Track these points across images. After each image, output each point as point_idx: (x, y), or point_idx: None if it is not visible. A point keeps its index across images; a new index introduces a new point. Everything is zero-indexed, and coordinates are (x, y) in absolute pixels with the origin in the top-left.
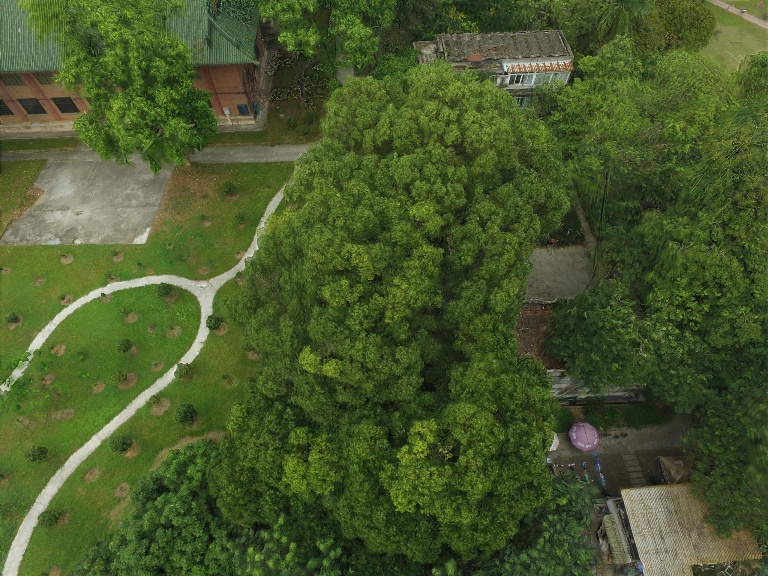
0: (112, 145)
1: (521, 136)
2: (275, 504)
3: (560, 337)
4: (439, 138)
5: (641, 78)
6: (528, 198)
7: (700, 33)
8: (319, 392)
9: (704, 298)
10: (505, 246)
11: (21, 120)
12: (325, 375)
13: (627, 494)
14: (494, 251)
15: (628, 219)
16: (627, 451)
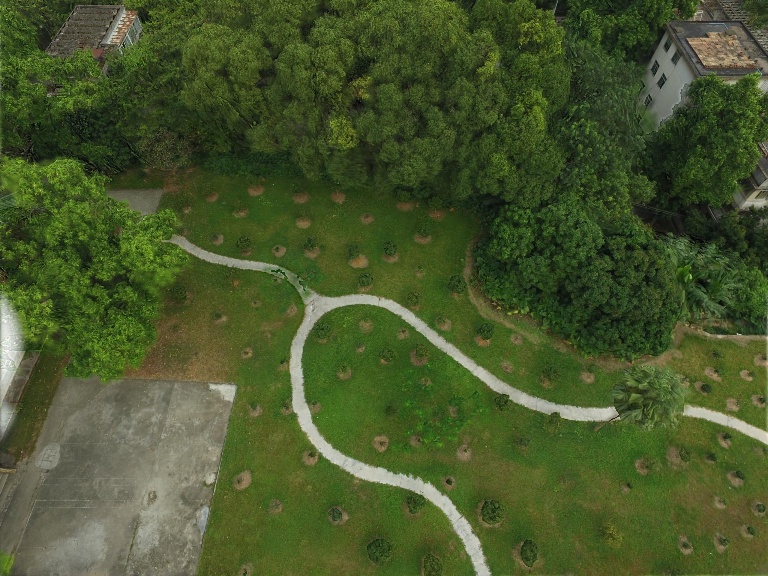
0: None
1: None
2: None
3: None
4: None
5: None
6: None
7: None
8: (498, 84)
9: None
10: None
11: None
12: None
13: None
14: None
15: None
16: None
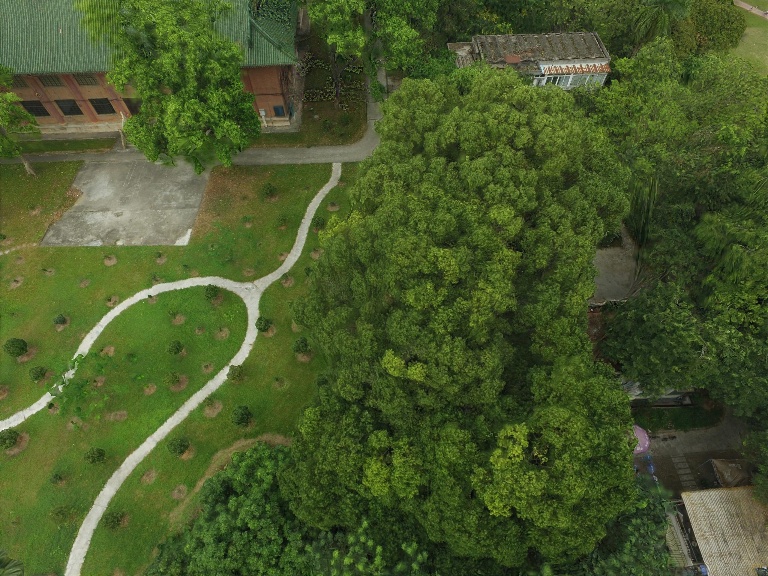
0: (160, 147)
1: (585, 139)
2: (355, 507)
3: (615, 340)
4: (509, 141)
5: (680, 80)
6: (592, 201)
7: (731, 35)
8: (401, 395)
9: (767, 301)
10: (578, 249)
11: (57, 121)
12: (409, 378)
13: (688, 497)
14: (569, 254)
15: (678, 221)
16: (676, 453)
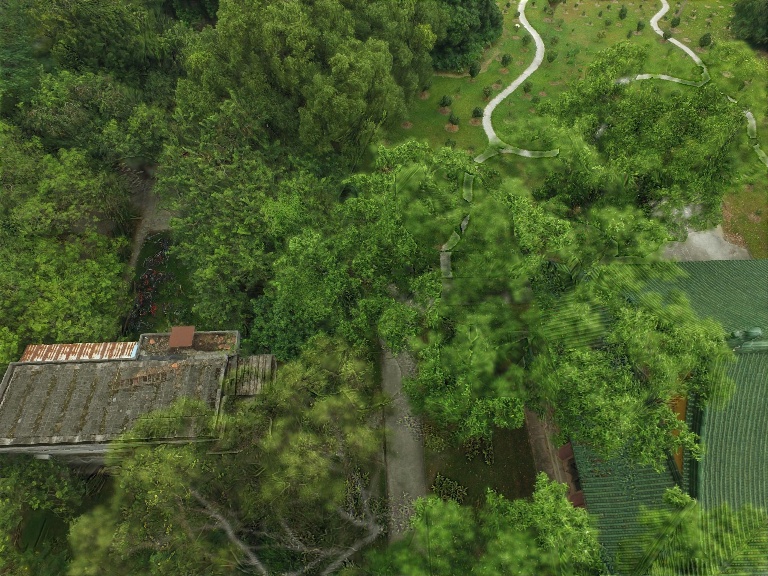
0: None
1: None
2: None
3: None
4: None
5: None
6: None
7: None
8: None
9: None
10: None
11: None
12: None
13: None
14: None
15: None
16: None
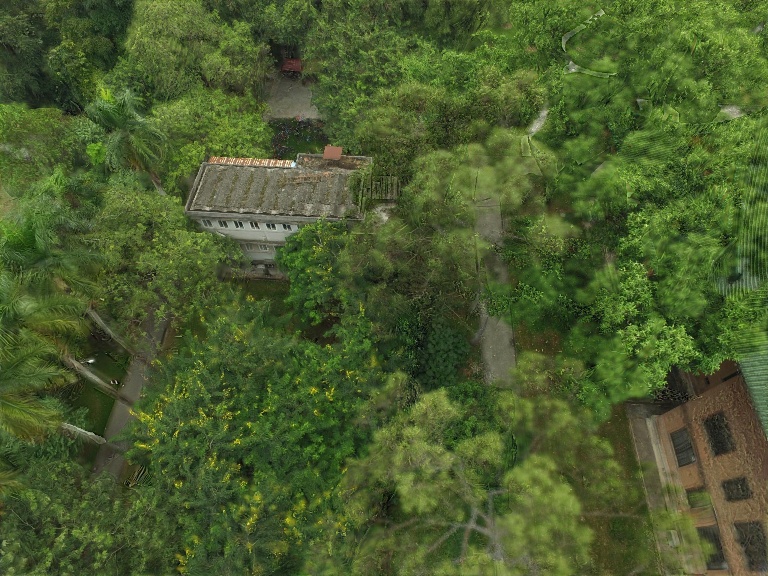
0: None
1: None
2: None
3: None
4: None
5: None
6: None
7: None
8: None
9: None
10: None
11: None
12: None
13: None
14: None
15: None
16: None
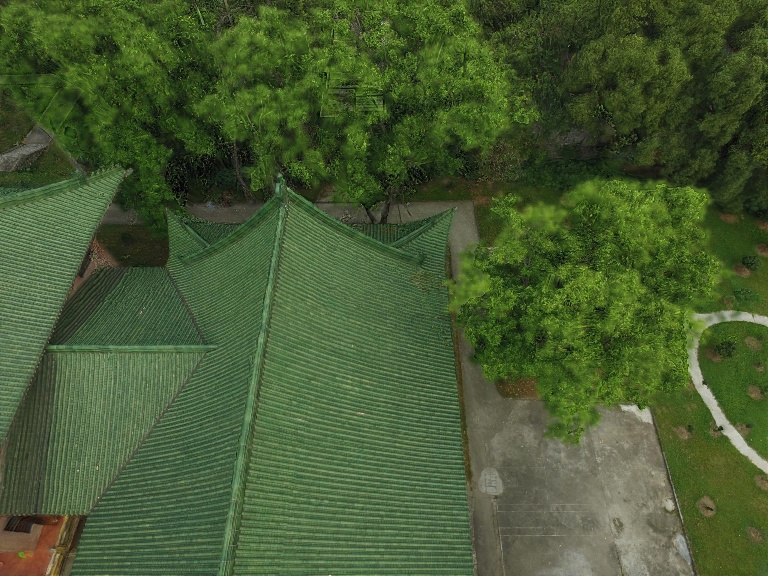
0: None
1: None
2: None
3: None
4: None
5: None
6: None
7: None
8: None
9: None
10: None
11: None
12: None
13: None
14: None
15: None
16: None
